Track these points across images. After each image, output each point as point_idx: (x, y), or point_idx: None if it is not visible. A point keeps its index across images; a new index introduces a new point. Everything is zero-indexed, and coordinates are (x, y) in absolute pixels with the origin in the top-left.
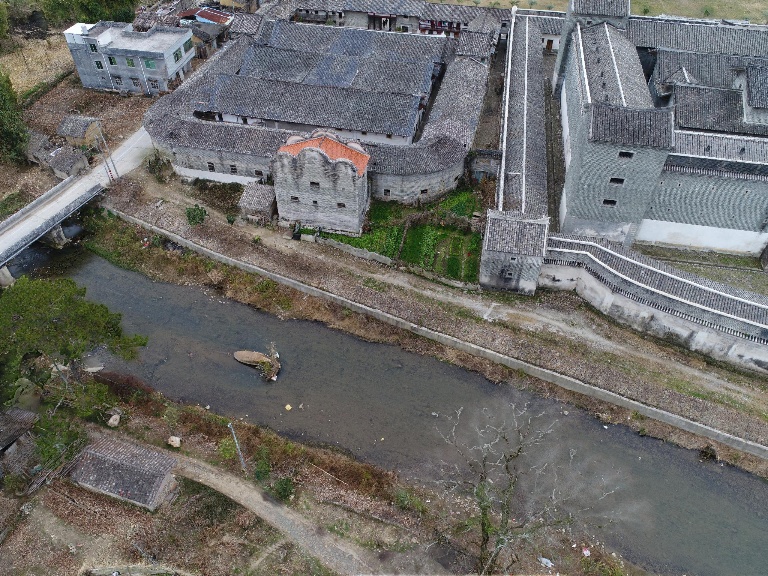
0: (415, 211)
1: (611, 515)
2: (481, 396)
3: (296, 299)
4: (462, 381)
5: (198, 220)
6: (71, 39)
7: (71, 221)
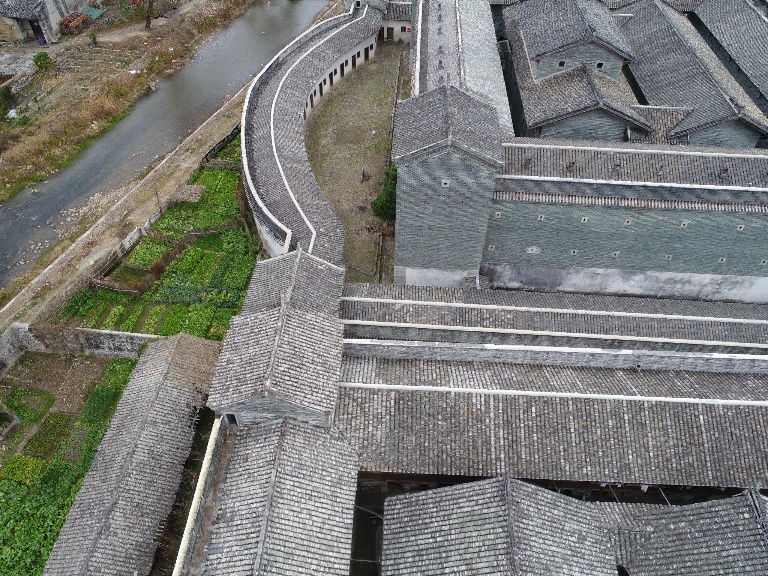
0: None
1: (195, 73)
2: (276, 45)
3: None
4: (287, 40)
5: None
6: None
7: None
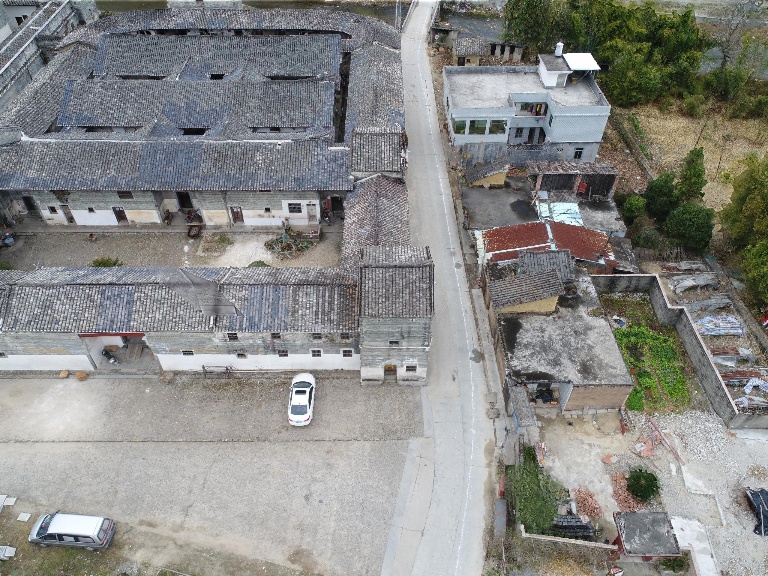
0: None
1: None
2: None
3: None
4: None
5: None
6: None
7: None
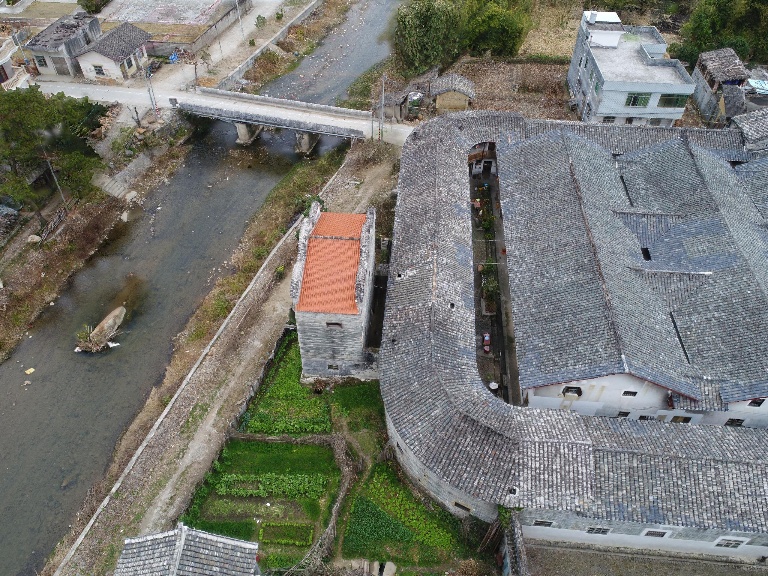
0: (373, 451)
1: None
2: None
3: (203, 342)
4: None
5: (307, 212)
6: (583, 22)
7: (338, 145)
